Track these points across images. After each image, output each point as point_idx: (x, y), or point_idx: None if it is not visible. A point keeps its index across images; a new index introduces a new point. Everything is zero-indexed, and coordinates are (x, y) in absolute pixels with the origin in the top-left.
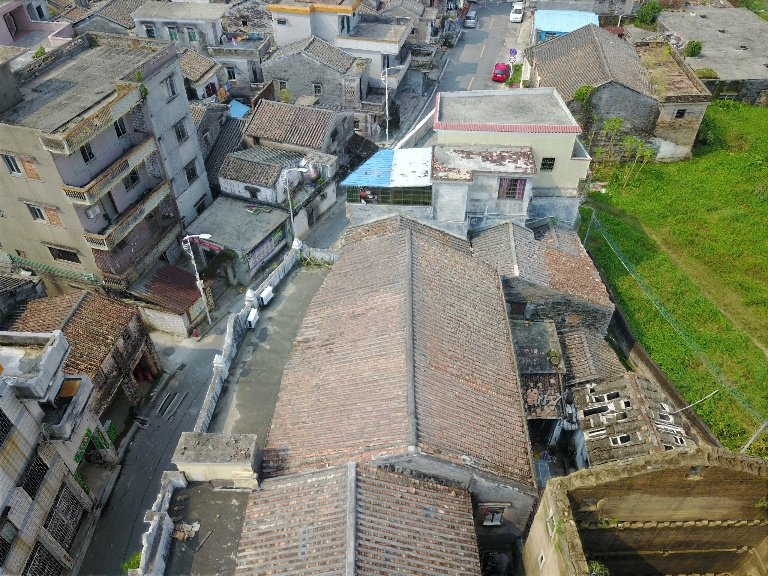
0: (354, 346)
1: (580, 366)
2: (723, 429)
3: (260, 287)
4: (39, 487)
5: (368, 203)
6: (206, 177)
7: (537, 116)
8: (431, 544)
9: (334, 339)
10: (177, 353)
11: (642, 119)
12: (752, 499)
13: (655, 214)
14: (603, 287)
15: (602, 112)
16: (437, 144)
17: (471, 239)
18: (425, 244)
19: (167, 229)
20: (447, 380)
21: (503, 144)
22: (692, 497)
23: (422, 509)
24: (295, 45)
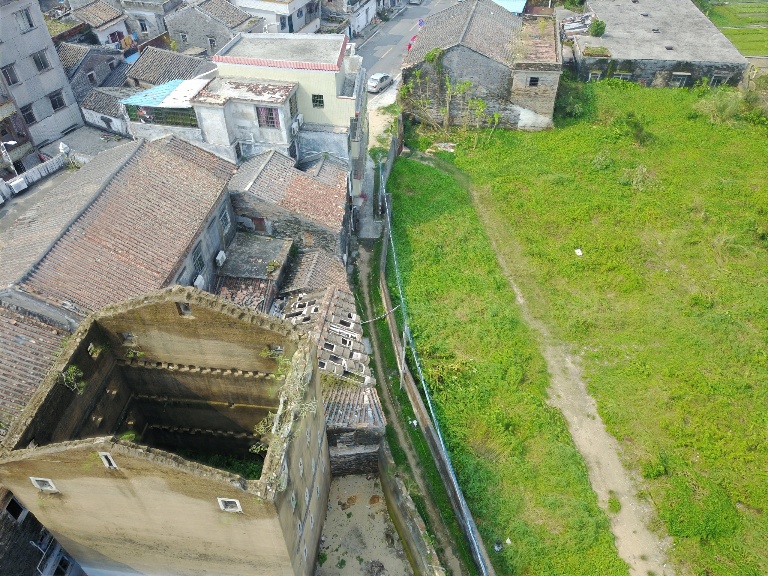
0: (45, 221)
1: (300, 278)
2: (427, 350)
3: (14, 178)
4: None
5: (147, 123)
6: (77, 108)
7: (312, 56)
8: (4, 360)
9: (39, 217)
10: None
11: (496, 85)
12: (257, 348)
13: (485, 173)
14: (341, 213)
15: (455, 75)
16: (218, 76)
17: (241, 164)
18: (156, 152)
19: (16, 145)
20: (95, 249)
21: (274, 79)
22: (204, 339)
23: (13, 336)
24: (197, 2)
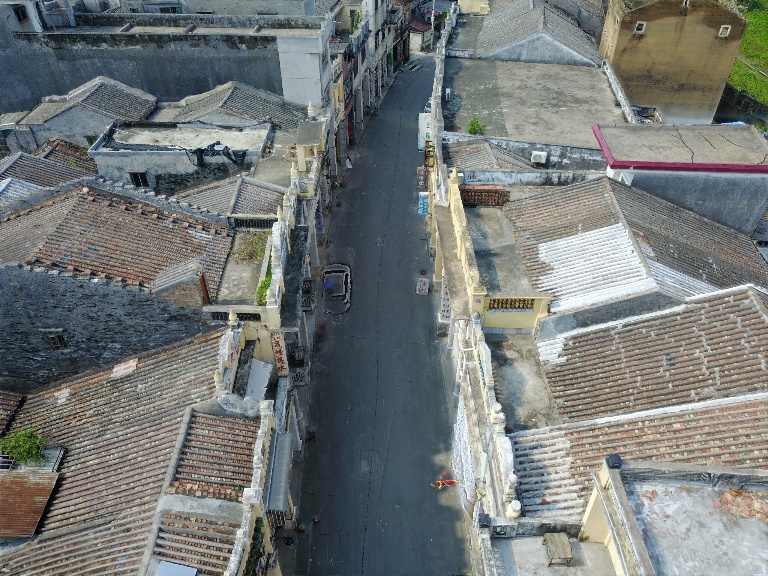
0: None
1: None
2: None
3: None
4: (382, 40)
5: None
6: None
7: None
8: None
9: None
10: (415, 55)
11: None
12: None
13: None
14: None
15: None
16: None
17: None
18: None
19: None
20: None
21: None
22: None
23: None
24: None
